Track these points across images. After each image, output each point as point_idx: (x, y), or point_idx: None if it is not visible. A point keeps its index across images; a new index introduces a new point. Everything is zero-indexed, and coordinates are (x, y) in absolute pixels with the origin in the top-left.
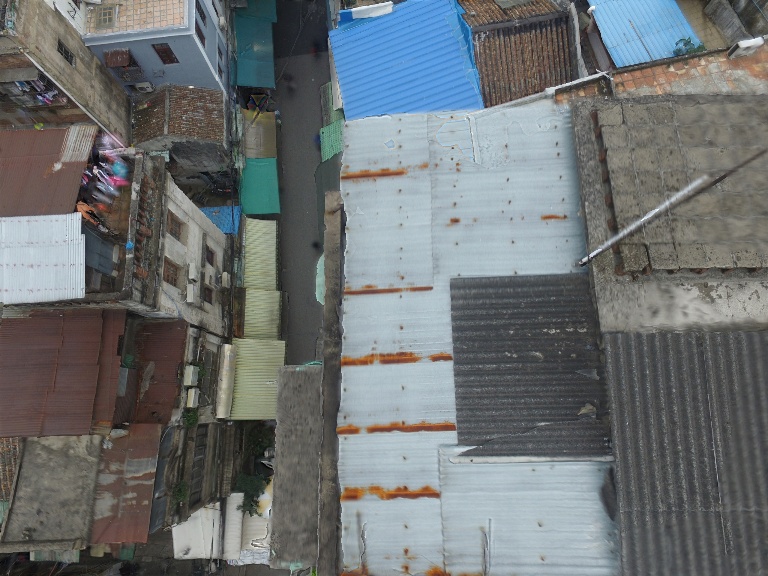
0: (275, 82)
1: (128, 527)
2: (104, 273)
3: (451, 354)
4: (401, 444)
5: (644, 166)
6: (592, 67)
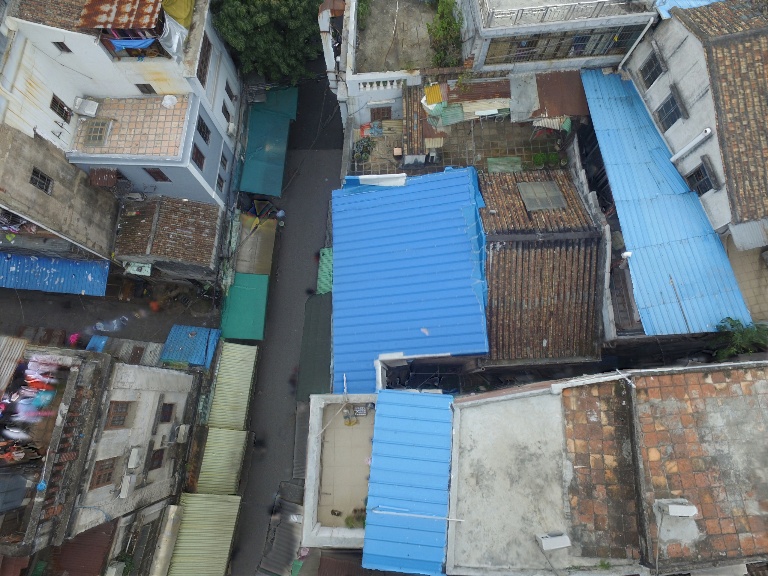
0: None
1: None
2: (9, 510)
3: None
4: None
5: None
6: (620, 295)
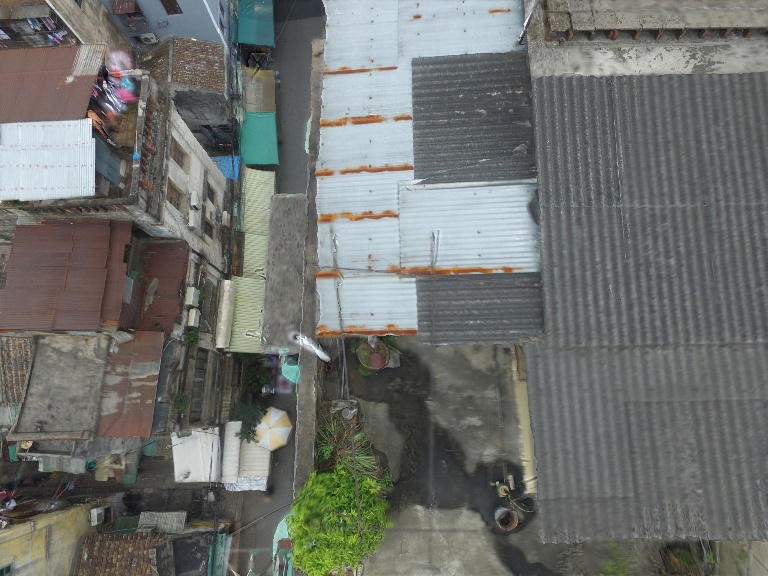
0: (275, 42)
1: (133, 423)
2: (112, 183)
3: (411, 116)
4: (368, 181)
5: None
6: None
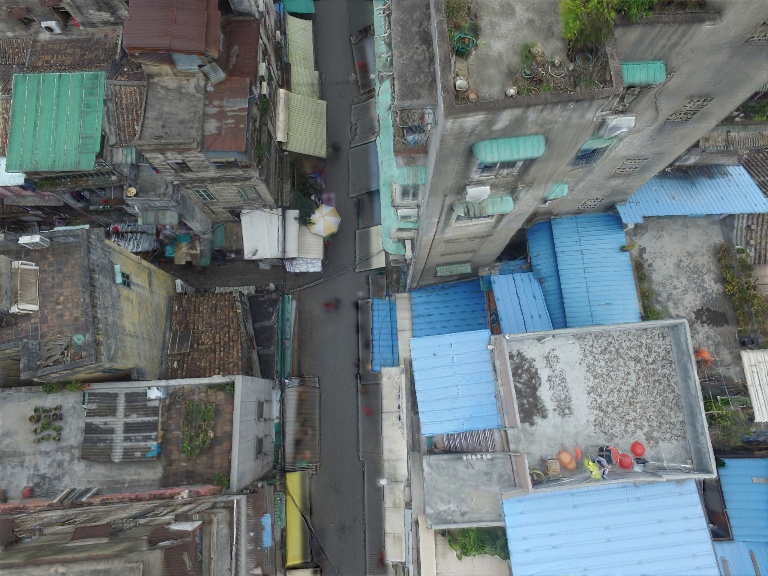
0: None
1: (230, 140)
2: None
3: None
4: None
5: None
6: None
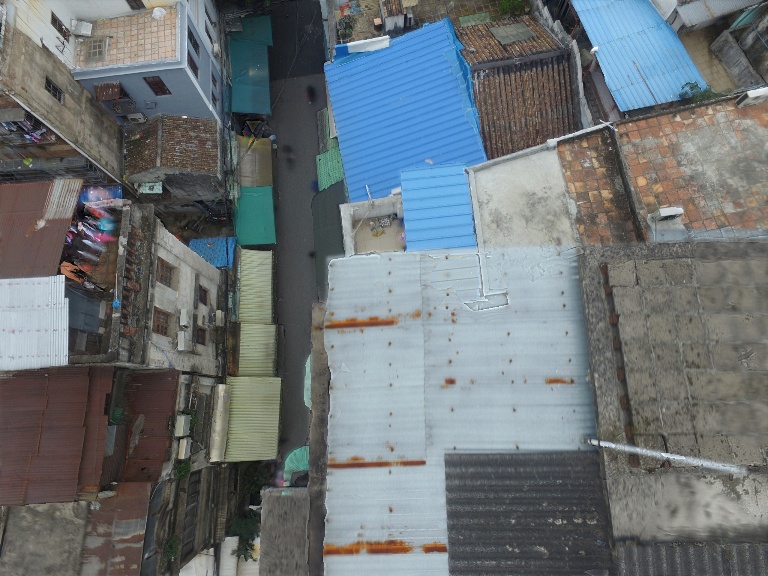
0: None
1: None
2: (90, 332)
3: (446, 544)
4: None
5: (661, 336)
6: (595, 105)
